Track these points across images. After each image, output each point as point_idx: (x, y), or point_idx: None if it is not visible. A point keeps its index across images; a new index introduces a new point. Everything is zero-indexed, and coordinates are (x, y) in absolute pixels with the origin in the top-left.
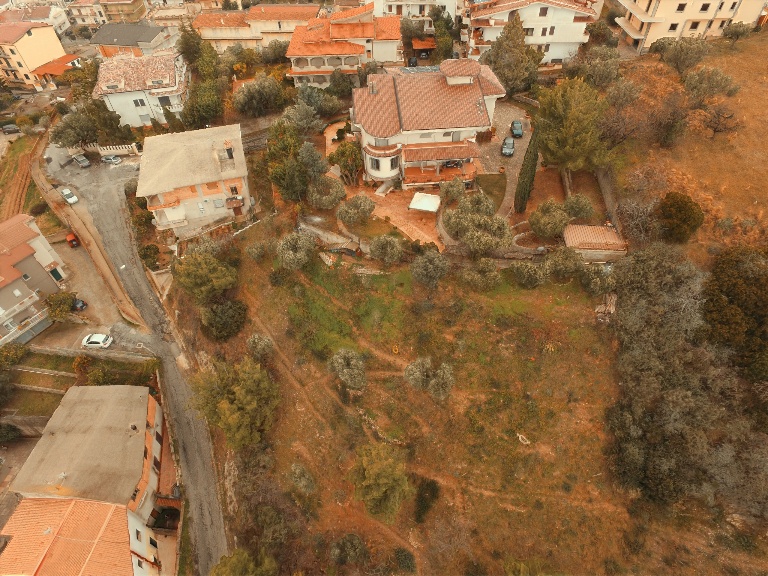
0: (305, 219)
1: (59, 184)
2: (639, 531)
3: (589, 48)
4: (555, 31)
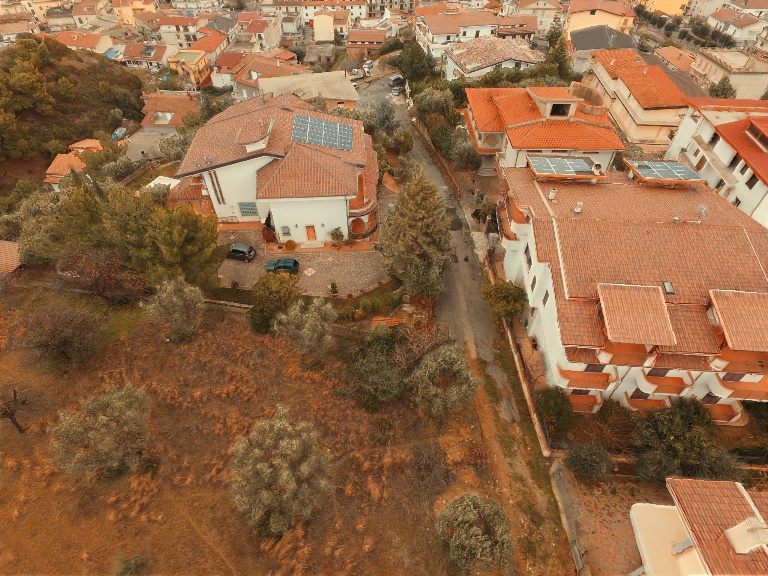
0: None
1: (371, 82)
2: None
3: (545, 395)
4: (548, 304)
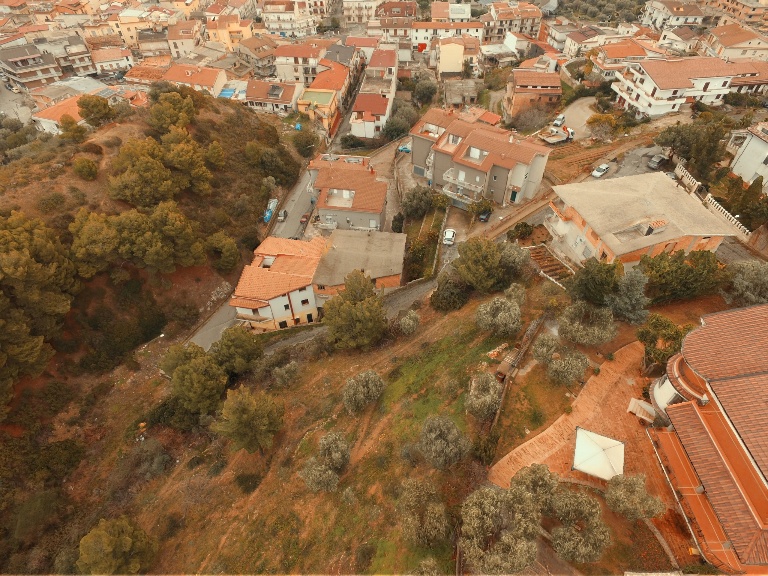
0: (553, 319)
1: (618, 161)
2: None
3: None
4: None
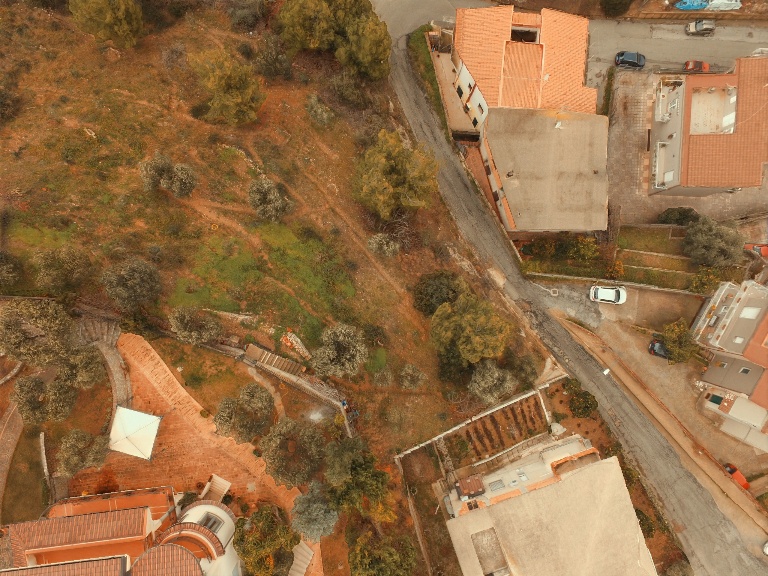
0: None
1: None
2: (15, 73)
3: None
4: None
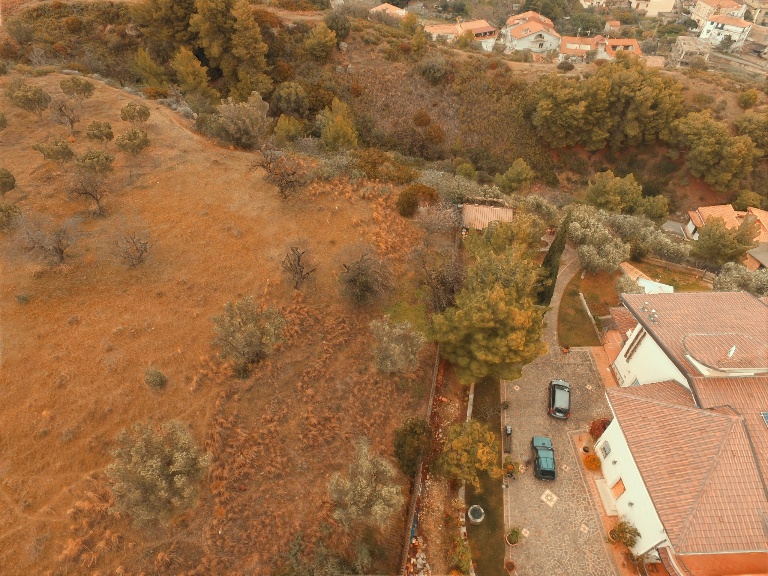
0: None
1: None
2: None
3: None
4: None
